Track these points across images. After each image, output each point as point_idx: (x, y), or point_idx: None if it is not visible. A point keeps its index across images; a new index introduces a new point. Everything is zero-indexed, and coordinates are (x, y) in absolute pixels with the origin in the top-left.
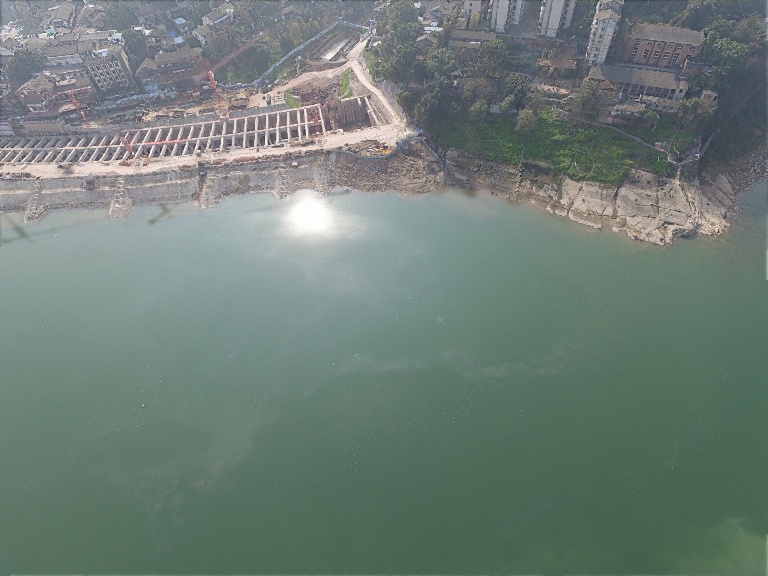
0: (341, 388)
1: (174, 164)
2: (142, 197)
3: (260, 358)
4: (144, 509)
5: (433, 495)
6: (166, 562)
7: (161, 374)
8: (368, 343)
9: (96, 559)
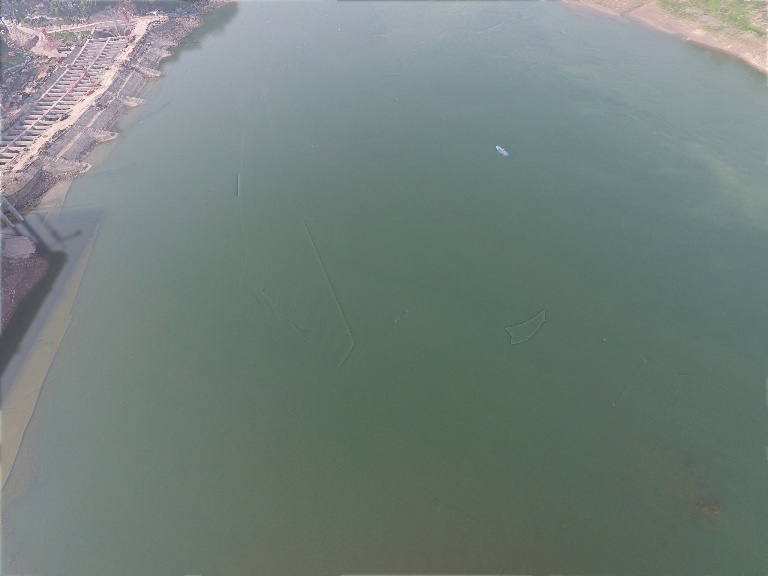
0: (305, 33)
1: (111, 76)
2: (130, 93)
3: (282, 49)
4: (342, 55)
5: (350, 21)
6: (361, 49)
7: (280, 67)
8: (286, 29)
9: (357, 63)
